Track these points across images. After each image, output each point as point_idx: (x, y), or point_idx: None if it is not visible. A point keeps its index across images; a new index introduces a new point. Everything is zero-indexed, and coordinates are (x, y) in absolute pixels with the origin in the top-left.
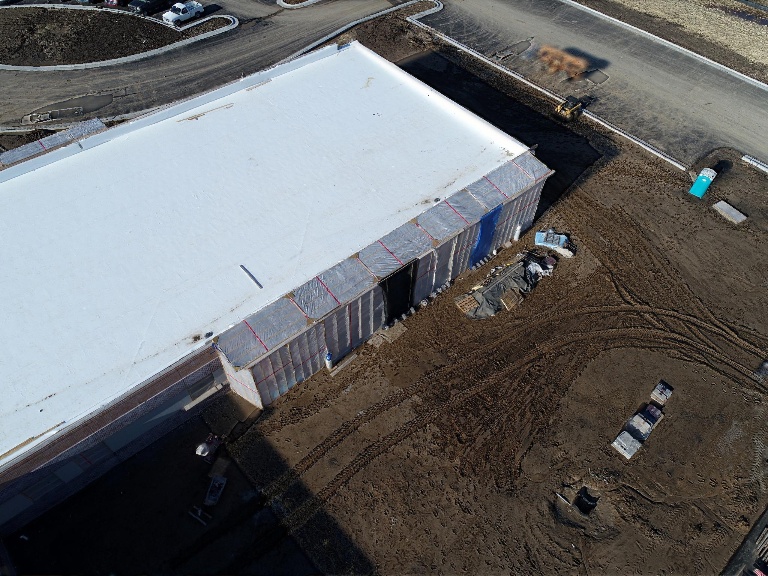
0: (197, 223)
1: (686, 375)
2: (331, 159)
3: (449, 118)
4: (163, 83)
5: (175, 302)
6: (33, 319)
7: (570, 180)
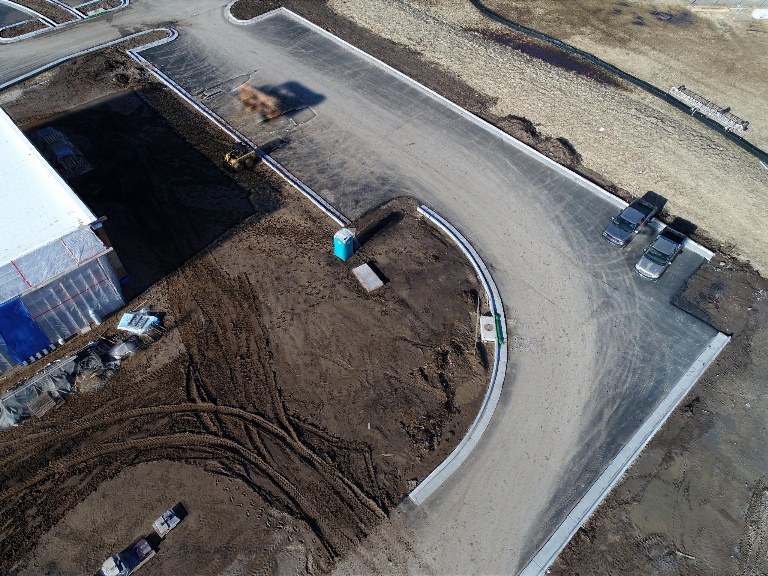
0: None
1: (212, 494)
2: None
3: (38, 183)
4: None
5: None
6: None
7: (203, 244)
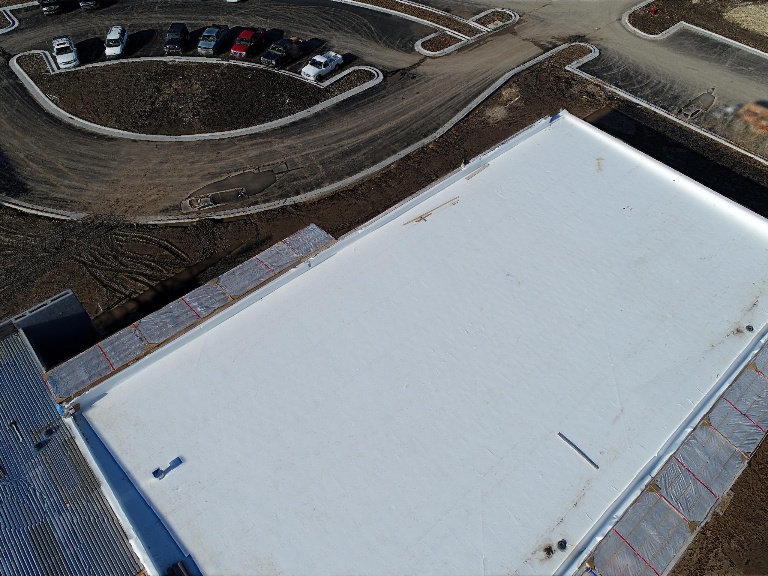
0: (482, 371)
1: None
2: (602, 273)
3: (712, 211)
4: (325, 154)
5: (501, 493)
6: (336, 527)
7: None
